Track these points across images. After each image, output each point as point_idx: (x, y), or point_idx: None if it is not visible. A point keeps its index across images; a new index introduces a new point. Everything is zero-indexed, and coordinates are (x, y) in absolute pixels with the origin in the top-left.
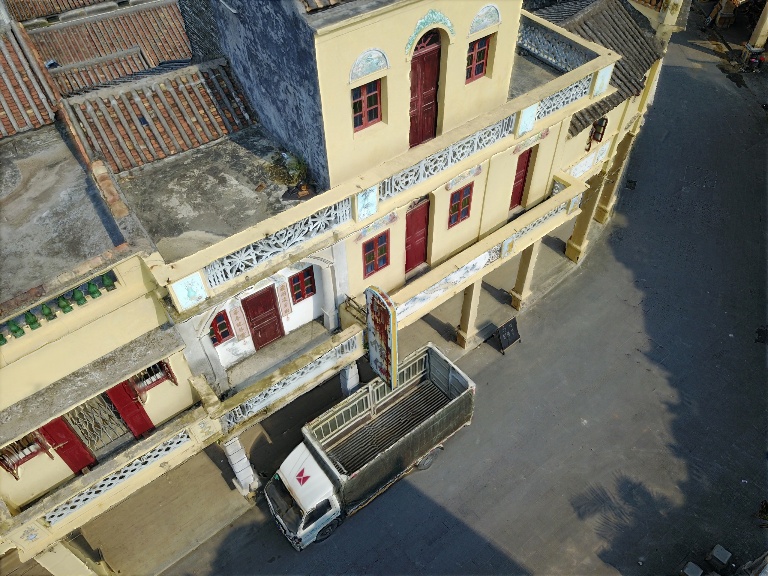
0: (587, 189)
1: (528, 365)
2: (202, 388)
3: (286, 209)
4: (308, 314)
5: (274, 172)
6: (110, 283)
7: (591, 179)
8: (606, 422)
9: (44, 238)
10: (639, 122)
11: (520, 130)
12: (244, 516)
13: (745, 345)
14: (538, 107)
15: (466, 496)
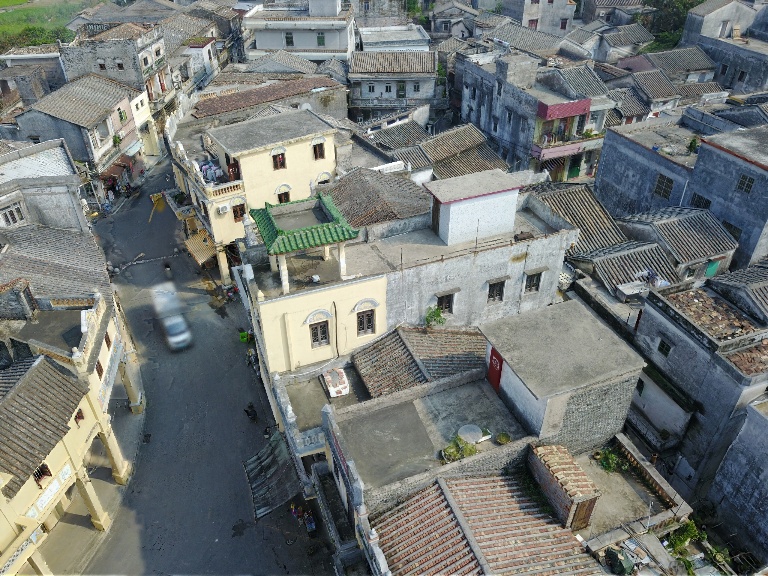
0: (39, 525)
1: None
2: None
3: None
4: None
5: None
6: None
7: (76, 483)
8: None
9: None
10: (104, 424)
11: None
12: None
13: (225, 544)
14: None
15: None
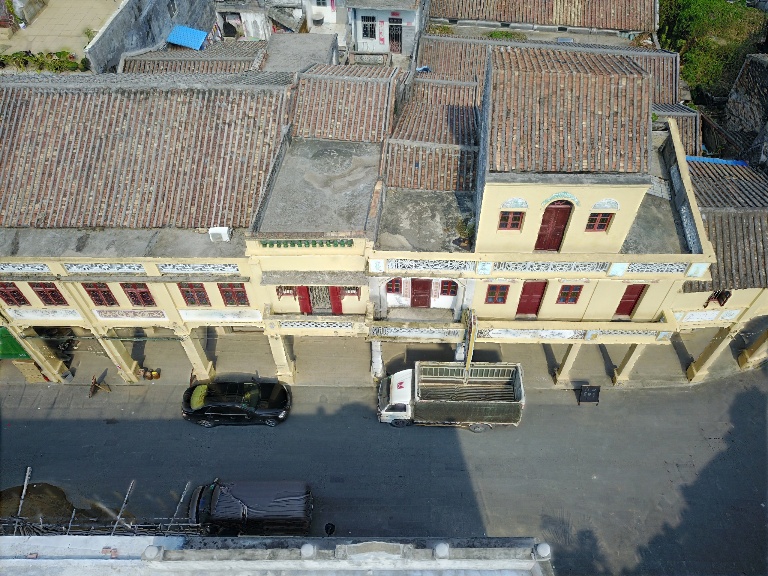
0: (676, 331)
1: (589, 422)
2: (370, 309)
3: (450, 248)
4: (448, 304)
5: (460, 225)
6: (350, 244)
7: (722, 329)
8: (608, 487)
9: (341, 205)
10: None
11: (611, 273)
12: (367, 388)
13: (767, 518)
14: (632, 265)
15: (485, 462)
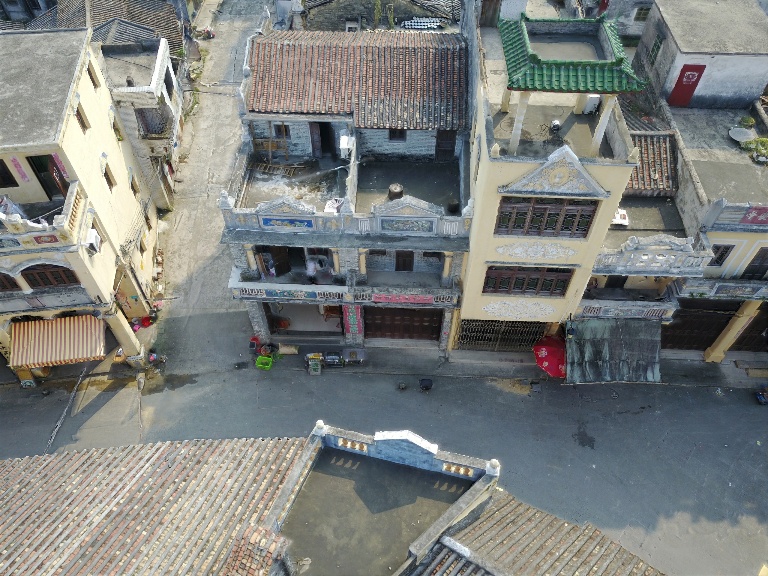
0: None
1: None
2: None
3: None
4: None
5: None
6: None
7: None
8: None
9: None
10: None
11: None
12: None
13: (601, 458)
14: None
15: None
